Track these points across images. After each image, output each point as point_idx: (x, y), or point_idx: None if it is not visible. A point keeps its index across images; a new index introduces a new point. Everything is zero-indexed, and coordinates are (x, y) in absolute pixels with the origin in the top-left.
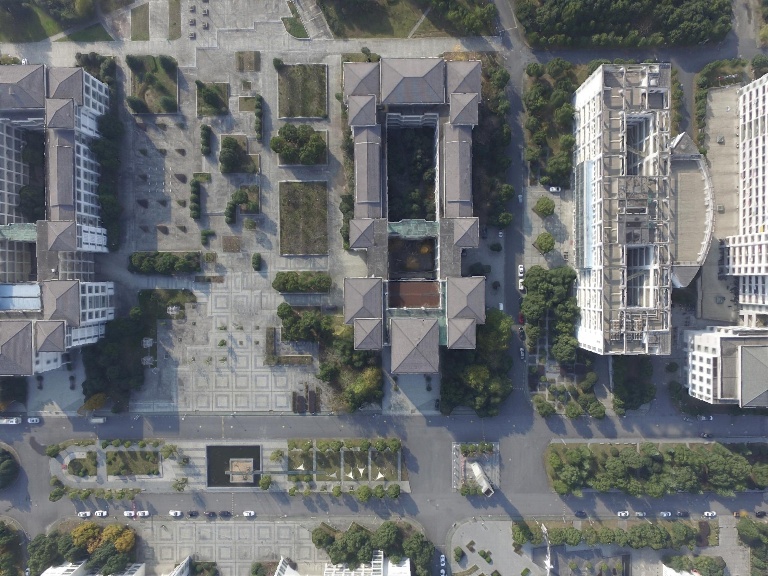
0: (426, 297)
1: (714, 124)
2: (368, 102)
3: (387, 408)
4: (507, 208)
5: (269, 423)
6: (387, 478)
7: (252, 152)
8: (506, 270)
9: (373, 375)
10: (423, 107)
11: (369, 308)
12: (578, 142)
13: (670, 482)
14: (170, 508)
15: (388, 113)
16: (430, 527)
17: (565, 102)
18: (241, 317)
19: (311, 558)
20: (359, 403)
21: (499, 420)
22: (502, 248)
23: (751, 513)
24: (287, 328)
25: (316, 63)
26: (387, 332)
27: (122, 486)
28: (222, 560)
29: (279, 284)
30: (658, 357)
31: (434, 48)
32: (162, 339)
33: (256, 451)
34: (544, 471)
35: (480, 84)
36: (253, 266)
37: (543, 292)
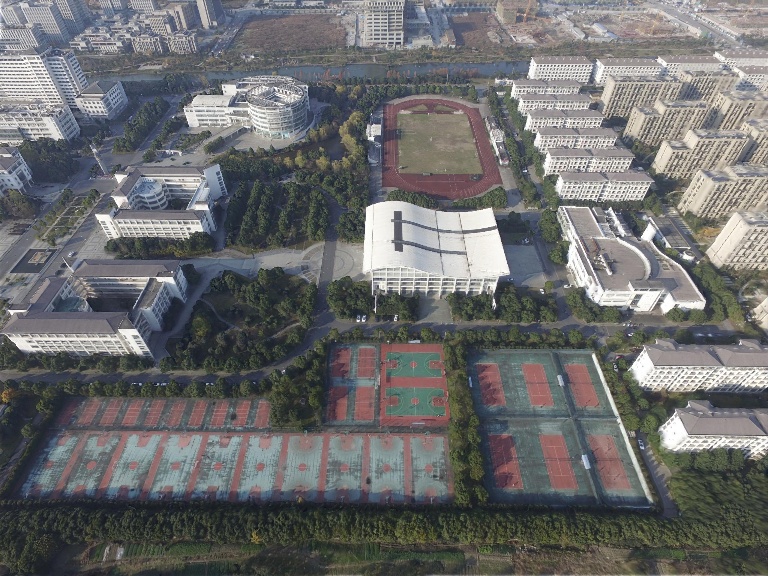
0: None
1: None
2: None
3: None
4: None
5: None
6: None
7: None
8: None
9: None
10: None
11: None
12: None
13: None
14: None
15: None
16: None
17: None
18: None
19: None
20: None
21: None
22: None
23: None
24: None
25: None
26: None
27: (1, 320)
28: None
29: None
30: None
31: None
32: None
33: (33, 251)
34: None
35: None
36: None
37: None
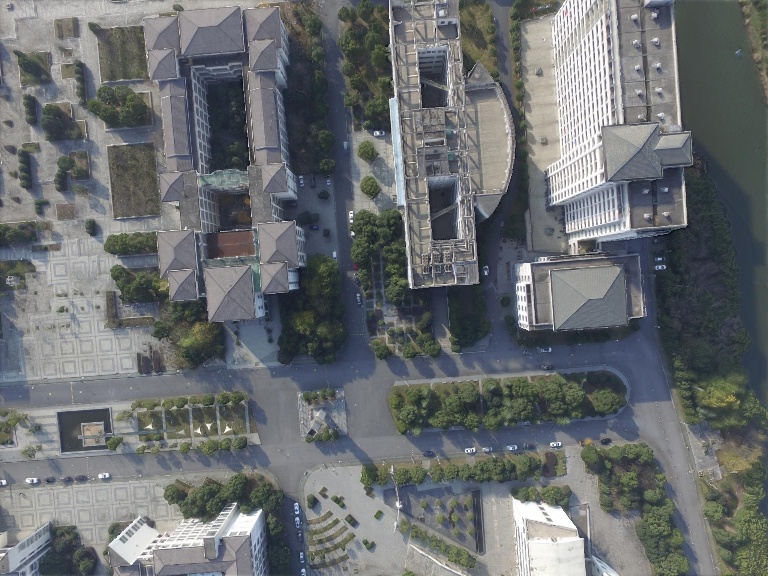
0: (244, 246)
1: (531, 56)
2: (167, 55)
3: (231, 363)
4: (334, 156)
5: (117, 386)
6: (236, 431)
7: (78, 119)
8: (337, 218)
9: (208, 329)
10: (226, 57)
11: (182, 259)
12: (393, 83)
13: (506, 414)
14: (27, 476)
15: (192, 66)
16: (282, 477)
17: (377, 44)
18: (81, 283)
19: (168, 515)
20: (199, 359)
21: (342, 367)
22: (332, 196)
23: (597, 441)
24: (121, 289)
25: (133, 25)
26: (204, 283)
27: None
28: (82, 523)
29: (109, 246)
30: (494, 293)
31: (249, 1)
32: (5, 310)
33: (106, 414)
34: (390, 414)
35: (280, 30)
36: (86, 231)
37: (367, 235)
